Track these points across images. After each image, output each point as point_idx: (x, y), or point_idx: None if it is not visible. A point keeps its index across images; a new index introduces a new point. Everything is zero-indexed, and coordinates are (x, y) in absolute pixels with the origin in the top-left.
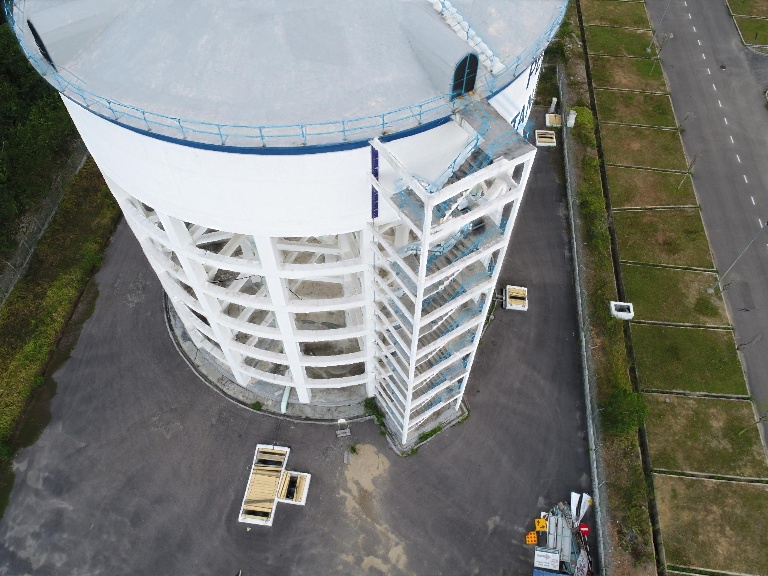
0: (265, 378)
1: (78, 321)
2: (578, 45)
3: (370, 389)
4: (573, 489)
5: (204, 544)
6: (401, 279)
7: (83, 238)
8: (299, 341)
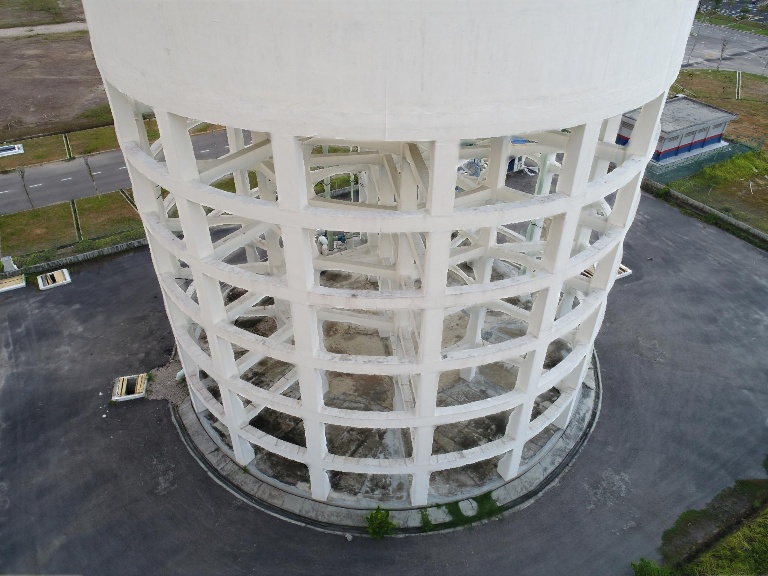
0: None
1: (711, 519)
2: None
3: None
4: None
5: (664, 281)
6: None
7: None
8: None
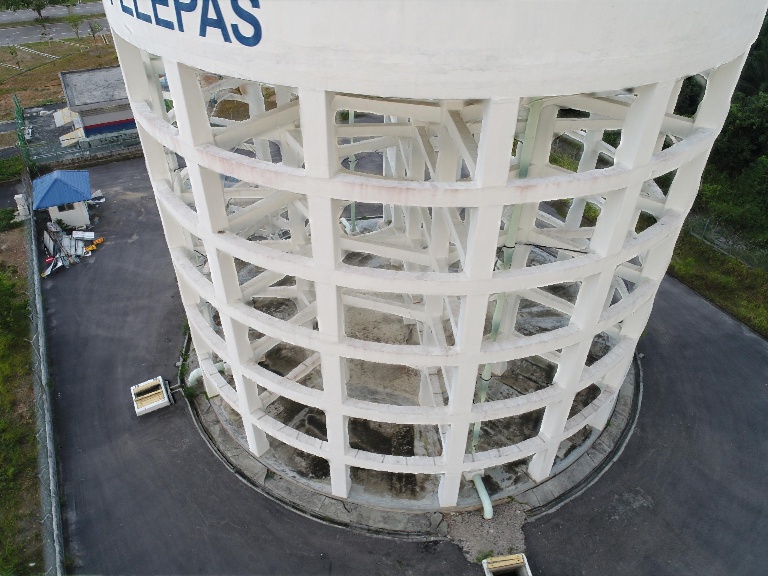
0: None
1: (561, 208)
2: None
3: None
4: (61, 276)
5: None
6: None
7: None
8: None
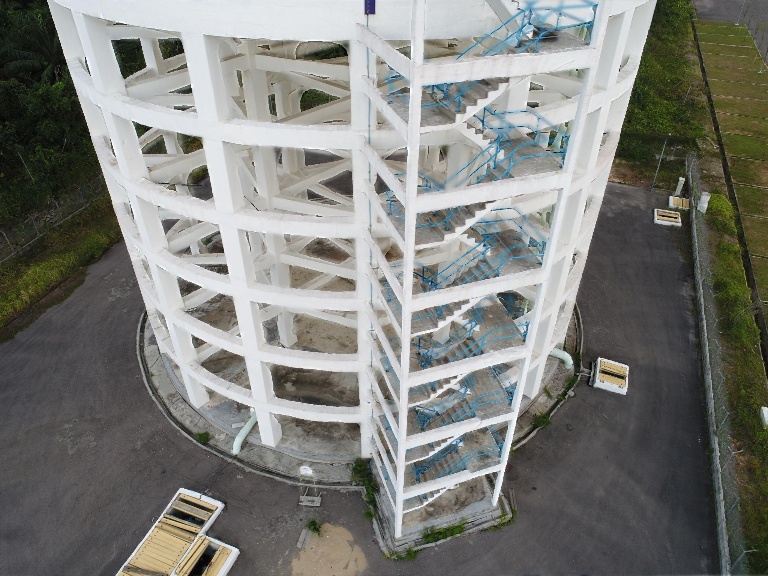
0: (216, 385)
1: (45, 304)
2: (713, 146)
3: (364, 439)
4: None
5: None
6: (393, 107)
7: (96, 230)
8: (255, 301)
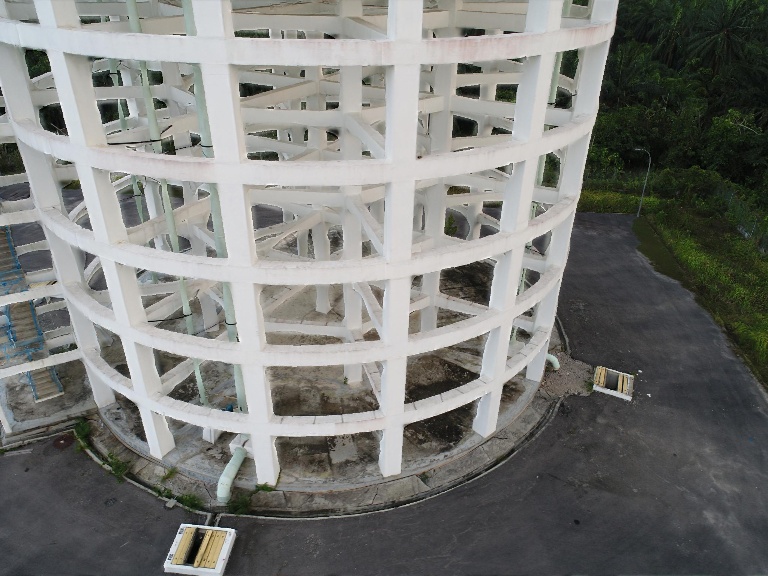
0: None
1: None
2: None
3: None
4: None
5: None
6: None
7: None
8: None
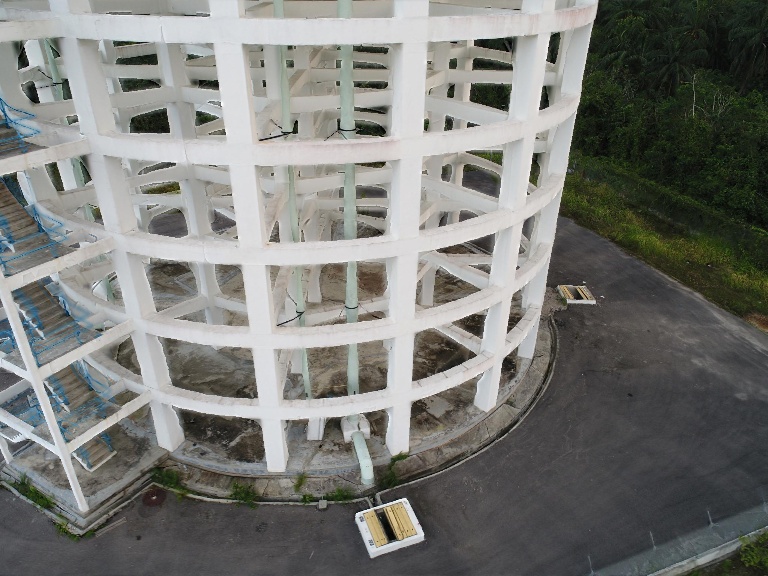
0: None
1: None
2: None
3: None
4: None
5: None
6: None
7: None
8: None
